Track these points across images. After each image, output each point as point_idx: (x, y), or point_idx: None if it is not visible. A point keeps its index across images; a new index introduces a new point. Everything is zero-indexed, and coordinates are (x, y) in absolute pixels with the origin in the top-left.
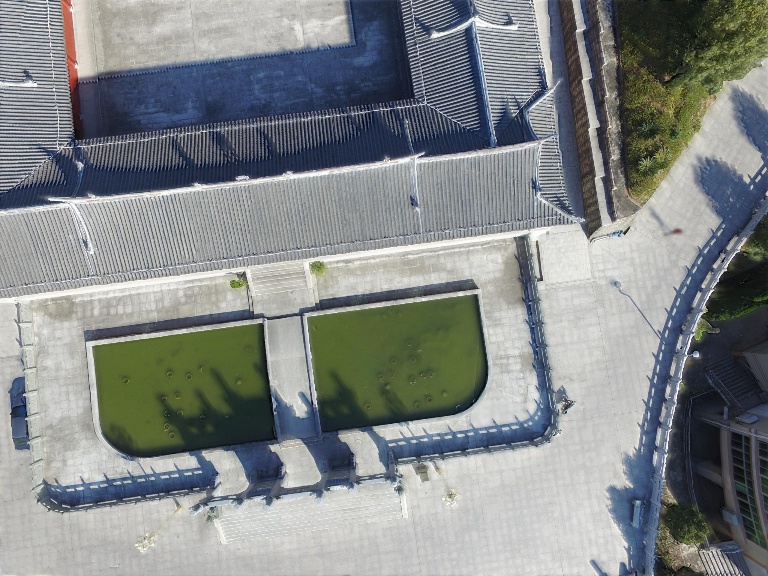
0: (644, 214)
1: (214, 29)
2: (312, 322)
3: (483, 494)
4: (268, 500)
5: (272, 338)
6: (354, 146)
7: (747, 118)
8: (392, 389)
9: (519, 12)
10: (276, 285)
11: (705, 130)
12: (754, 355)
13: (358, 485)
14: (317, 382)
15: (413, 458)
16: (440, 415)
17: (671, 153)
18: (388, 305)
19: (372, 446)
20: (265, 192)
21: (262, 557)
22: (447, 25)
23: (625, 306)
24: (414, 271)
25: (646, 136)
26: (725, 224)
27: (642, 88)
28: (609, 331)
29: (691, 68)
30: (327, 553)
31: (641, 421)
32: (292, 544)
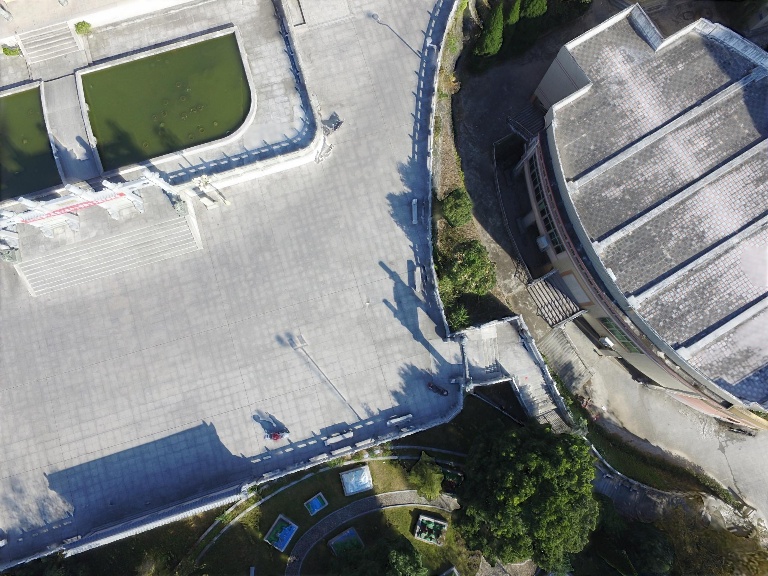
0: None
1: None
2: (89, 81)
3: (271, 218)
4: None
5: (49, 95)
6: None
7: None
8: (166, 126)
9: None
10: (49, 50)
11: None
12: (539, 87)
13: (117, 184)
14: (100, 134)
15: (193, 185)
16: (211, 141)
17: None
18: (153, 53)
19: None
20: None
21: (71, 304)
22: None
23: (384, 34)
24: (177, 24)
25: None
26: None
27: None
28: (372, 58)
29: None
30: (131, 291)
31: (412, 132)
32: (98, 288)
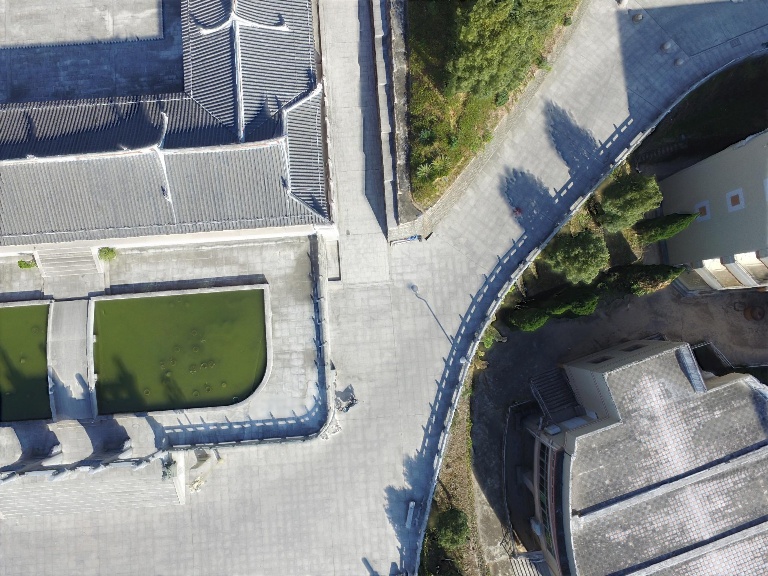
0: (447, 221)
1: (26, 15)
2: (102, 306)
3: (262, 486)
4: (9, 475)
5: (56, 319)
6: (110, 135)
7: (558, 133)
8: (172, 377)
9: (293, 14)
10: (66, 268)
11: (515, 142)
12: (569, 368)
13: (105, 467)
14: (102, 365)
15: (188, 446)
16: (216, 405)
17: (451, 161)
18: (175, 294)
19: (149, 431)
20: (15, 174)
21: (39, 534)
22: (216, 23)
23: (420, 310)
24: (207, 263)
25: (424, 143)
26: (527, 235)
27: (423, 96)
28: (402, 334)
29: (452, 78)
30: (103, 534)
31: (426, 424)
32: (69, 523)
